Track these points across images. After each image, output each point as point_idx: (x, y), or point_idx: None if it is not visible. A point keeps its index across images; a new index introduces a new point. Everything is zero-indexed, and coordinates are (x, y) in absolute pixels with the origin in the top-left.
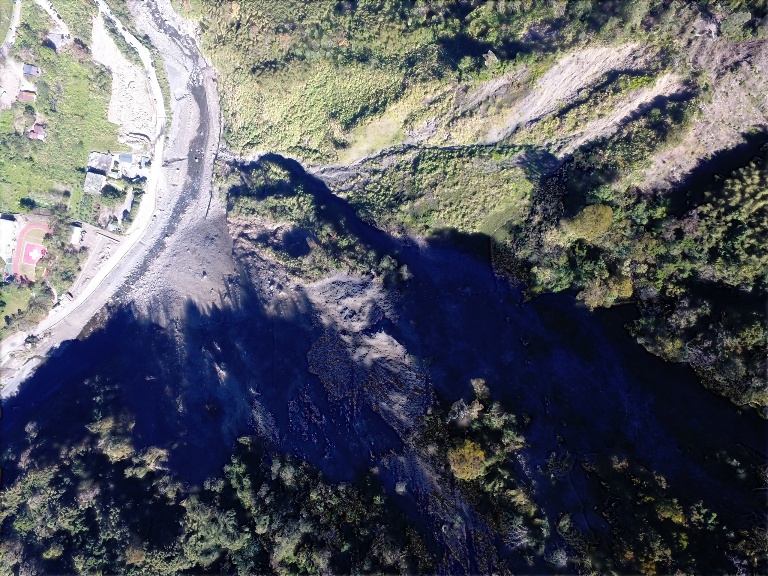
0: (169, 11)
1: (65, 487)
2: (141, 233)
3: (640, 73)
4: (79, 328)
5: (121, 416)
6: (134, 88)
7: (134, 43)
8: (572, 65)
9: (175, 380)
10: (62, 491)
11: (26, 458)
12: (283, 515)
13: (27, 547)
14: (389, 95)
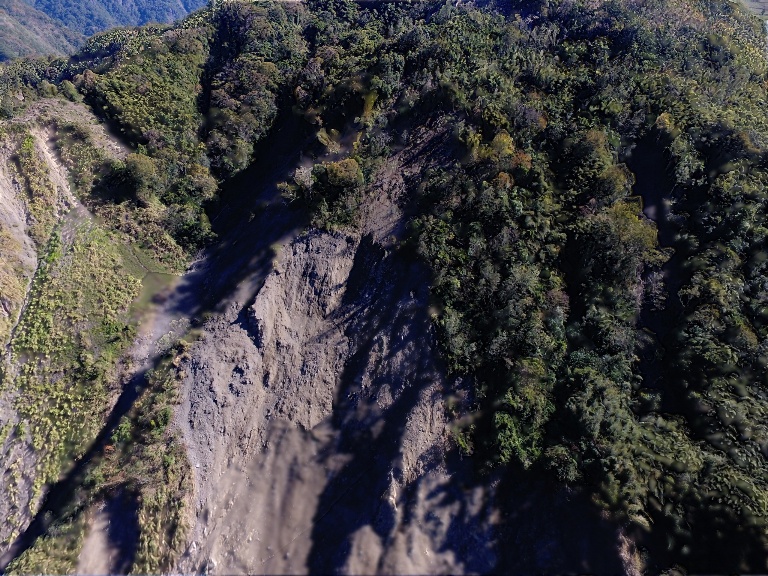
0: None
1: None
2: None
3: None
4: None
5: None
6: None
7: None
8: None
9: None
10: None
11: None
12: None
13: None
14: None
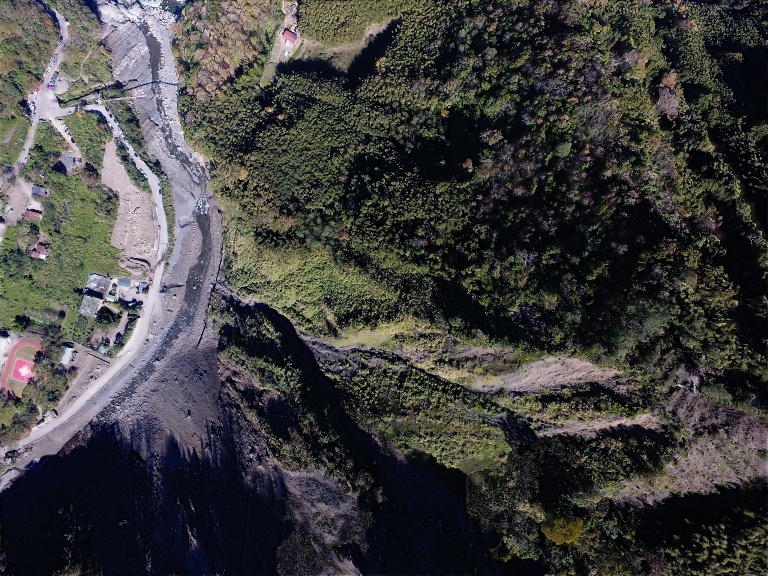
0: (182, 138)
1: None
2: (132, 356)
3: (621, 400)
4: (61, 444)
5: (90, 561)
6: (140, 214)
7: (144, 169)
8: (557, 365)
9: (147, 530)
10: None
11: None
12: None
13: None
14: (382, 310)
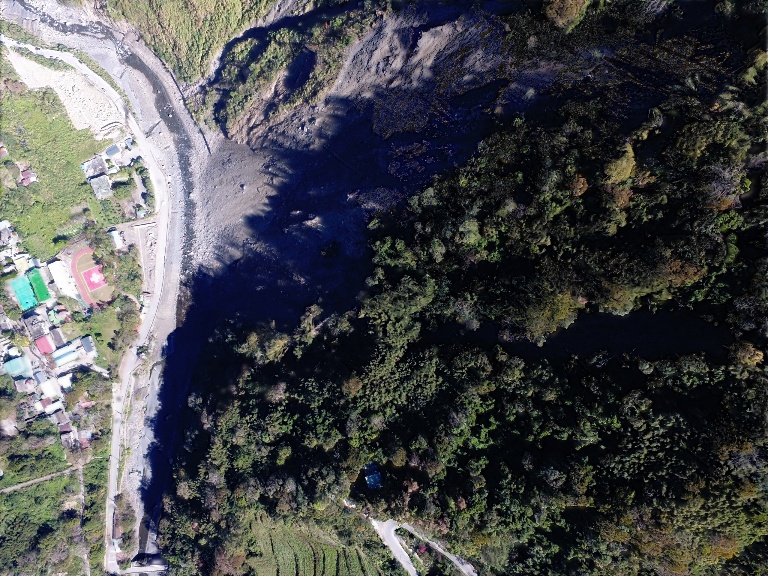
0: (63, 13)
1: (255, 407)
2: (168, 203)
3: None
4: (173, 317)
5: (258, 331)
6: (79, 90)
7: (53, 55)
8: None
9: (281, 271)
10: (255, 411)
11: (207, 418)
12: (449, 224)
13: (259, 475)
14: None
